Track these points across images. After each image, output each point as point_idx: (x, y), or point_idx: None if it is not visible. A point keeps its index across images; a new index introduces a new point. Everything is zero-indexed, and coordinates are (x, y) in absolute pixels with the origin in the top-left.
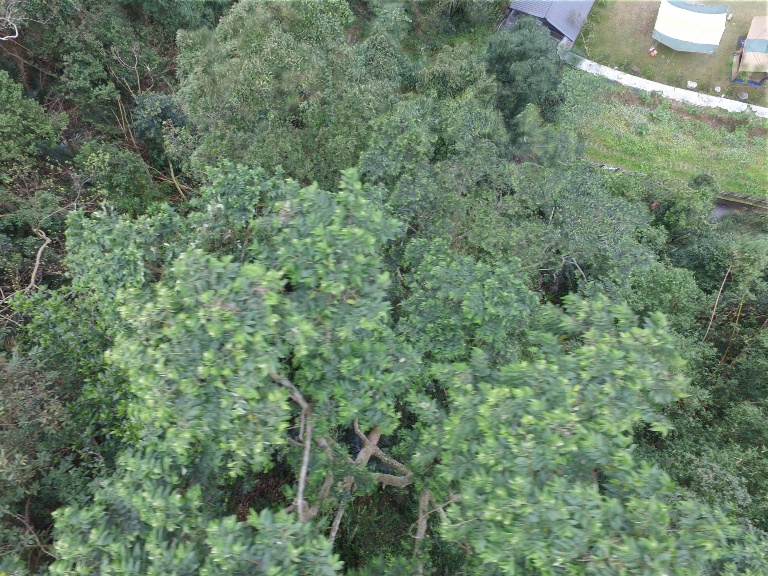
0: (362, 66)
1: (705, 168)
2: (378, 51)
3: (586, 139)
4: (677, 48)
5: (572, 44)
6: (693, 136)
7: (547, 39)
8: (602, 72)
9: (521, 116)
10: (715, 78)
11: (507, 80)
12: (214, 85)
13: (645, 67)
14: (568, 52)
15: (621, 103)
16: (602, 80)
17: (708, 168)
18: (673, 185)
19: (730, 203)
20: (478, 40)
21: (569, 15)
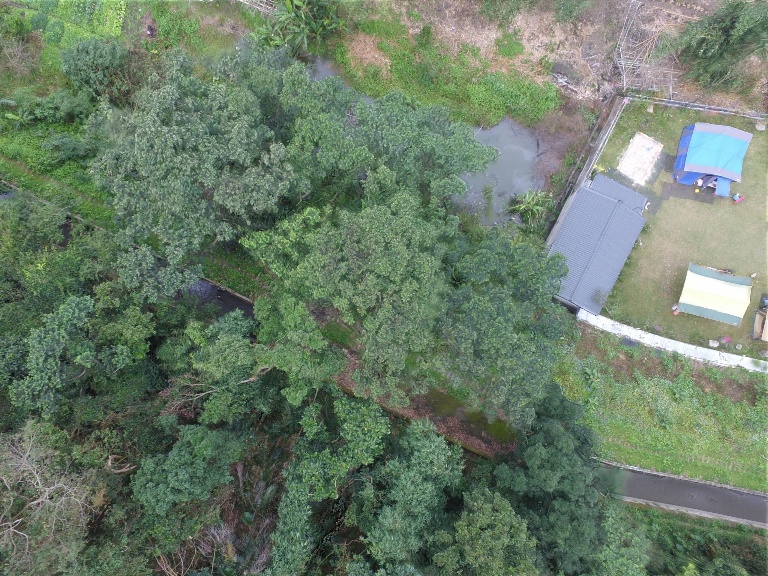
0: (402, 523)
1: (727, 462)
2: (416, 488)
3: (610, 436)
4: (700, 314)
5: None
6: (715, 417)
7: (585, 471)
8: (624, 332)
9: (558, 553)
10: (737, 336)
11: (544, 512)
12: (245, 460)
13: (667, 325)
14: None
15: (644, 376)
16: (624, 342)
17: (730, 462)
18: None
19: (750, 495)
20: None
21: (594, 293)
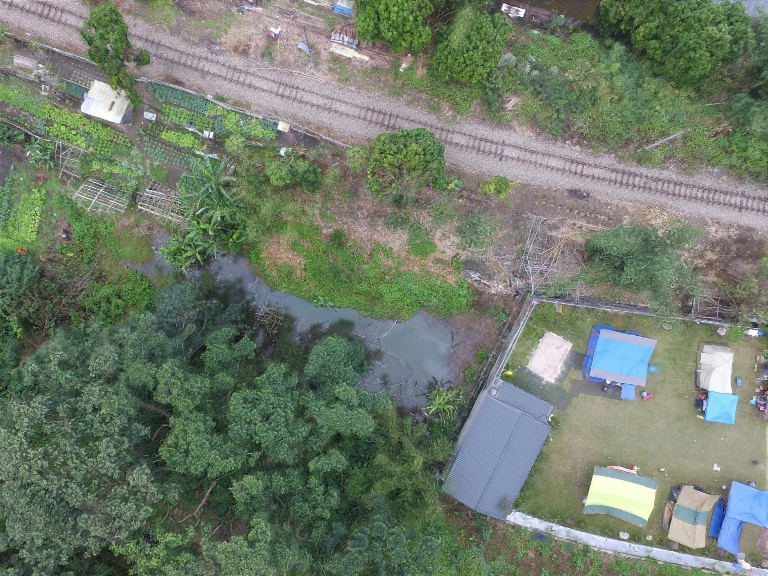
0: None
1: None
2: None
3: None
4: (608, 512)
5: None
6: None
7: None
8: (536, 525)
9: None
10: (647, 527)
11: None
12: None
13: (578, 518)
14: None
15: None
16: (535, 537)
17: None
18: None
19: None
20: None
21: (500, 500)
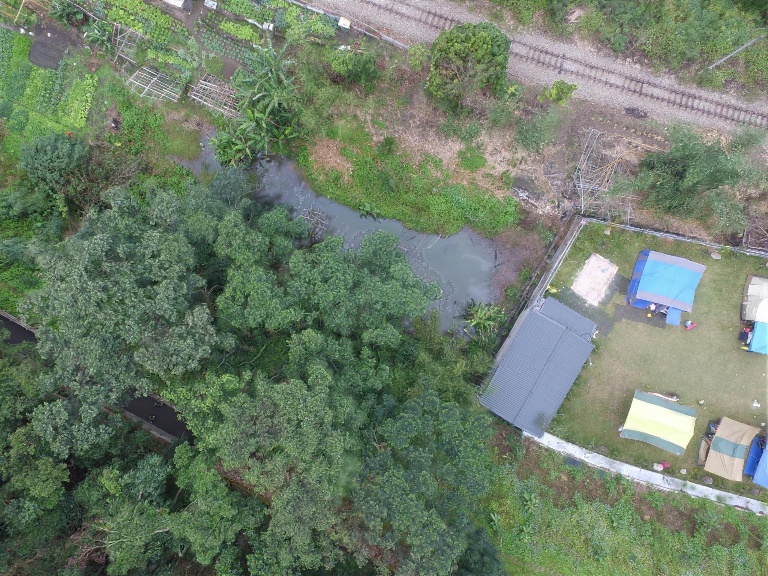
0: None
1: None
2: None
3: (543, 565)
4: (645, 440)
5: None
6: (651, 547)
7: None
8: (569, 450)
9: None
10: (682, 460)
11: None
12: None
13: (613, 446)
14: None
15: (584, 501)
16: (568, 461)
17: None
18: None
19: None
20: None
21: (538, 416)
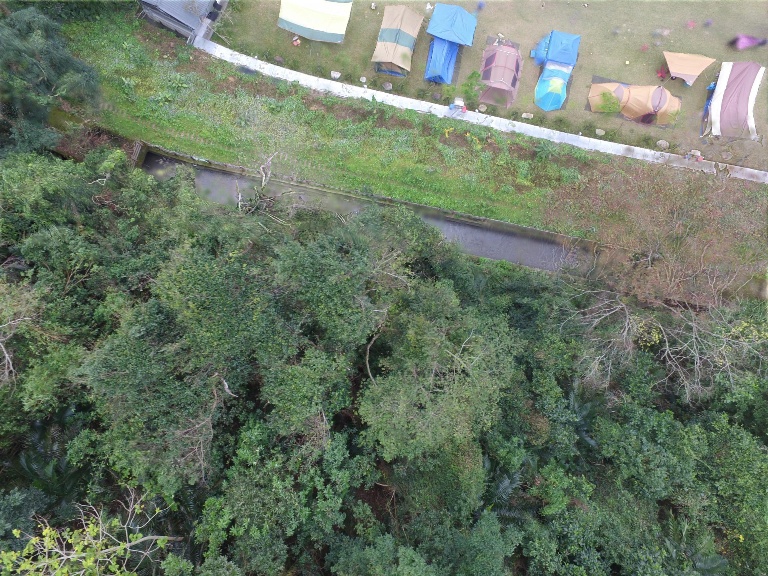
0: None
1: (305, 159)
2: None
3: (182, 130)
4: (311, 37)
5: (211, 33)
6: (310, 127)
7: None
8: (243, 62)
9: None
10: (360, 68)
11: None
12: None
13: (289, 57)
14: (208, 41)
15: (246, 93)
16: (241, 70)
17: (308, 159)
18: (133, 176)
19: (331, 195)
20: (95, 28)
21: (186, 3)
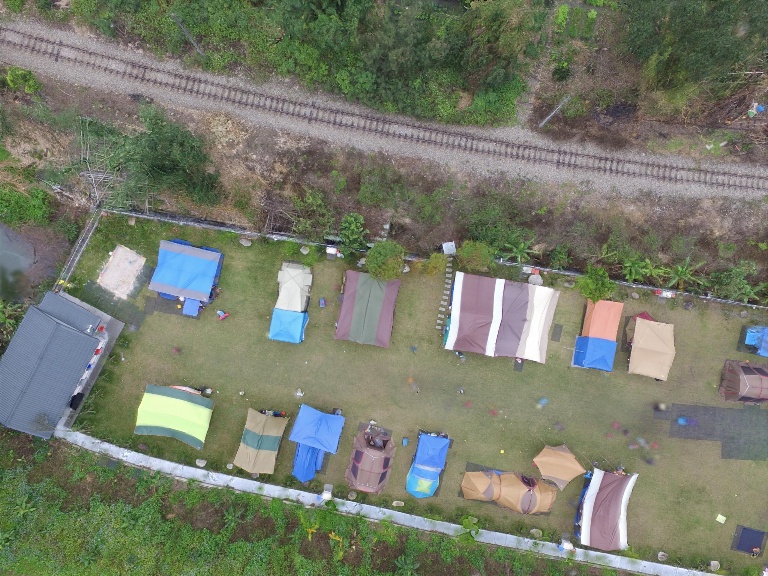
0: None
1: None
2: None
3: (22, 573)
4: (173, 435)
5: (73, 422)
6: (163, 547)
7: None
8: (106, 450)
9: None
10: (227, 455)
11: None
12: None
13: (153, 443)
14: None
15: (101, 502)
16: (102, 461)
17: None
18: None
19: None
20: None
21: (38, 416)
